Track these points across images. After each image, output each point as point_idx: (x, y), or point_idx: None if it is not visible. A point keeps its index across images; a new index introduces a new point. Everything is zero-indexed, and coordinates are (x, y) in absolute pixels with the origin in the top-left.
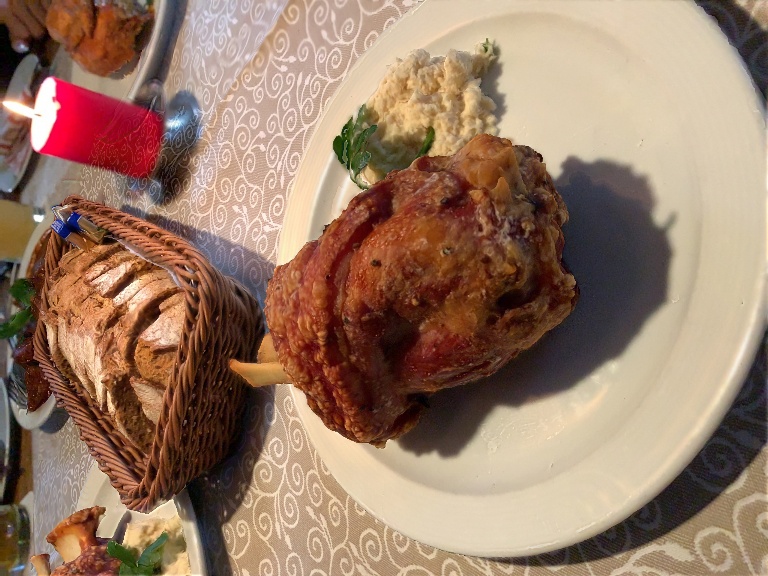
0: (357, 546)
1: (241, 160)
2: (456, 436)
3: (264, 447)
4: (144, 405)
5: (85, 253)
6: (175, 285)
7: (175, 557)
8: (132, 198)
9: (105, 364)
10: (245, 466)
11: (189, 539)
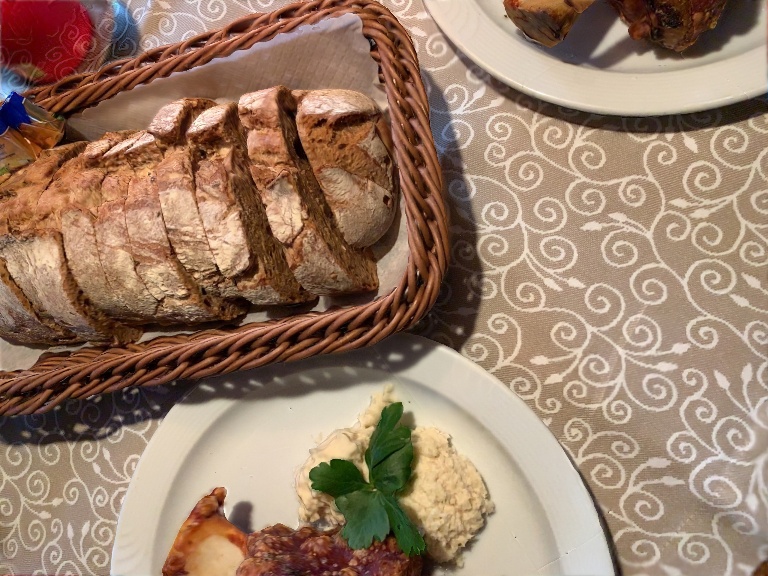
0: (683, 195)
1: (245, 0)
2: (746, 12)
3: (477, 223)
4: (337, 205)
5: (23, 168)
6: None
7: (412, 436)
8: None
9: (233, 196)
10: (462, 258)
11: (447, 369)
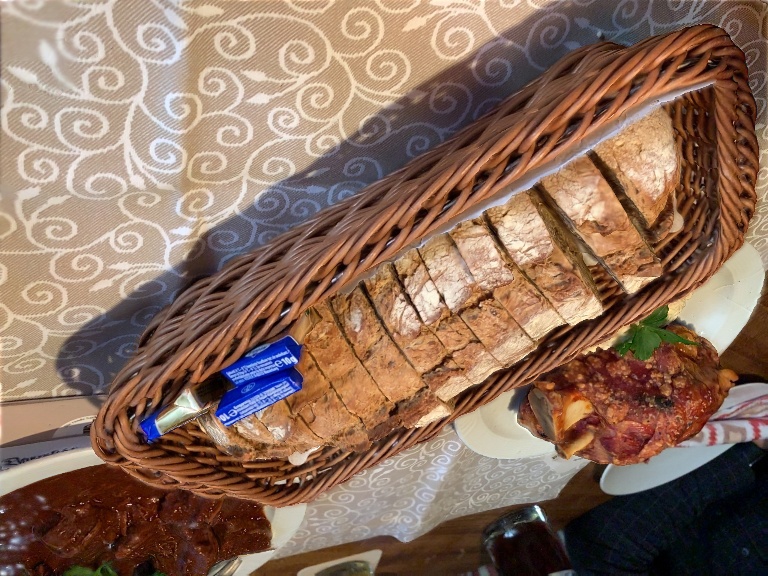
0: None
1: None
2: None
3: None
4: None
5: None
6: None
7: None
8: (93, 304)
9: None
10: None
11: None
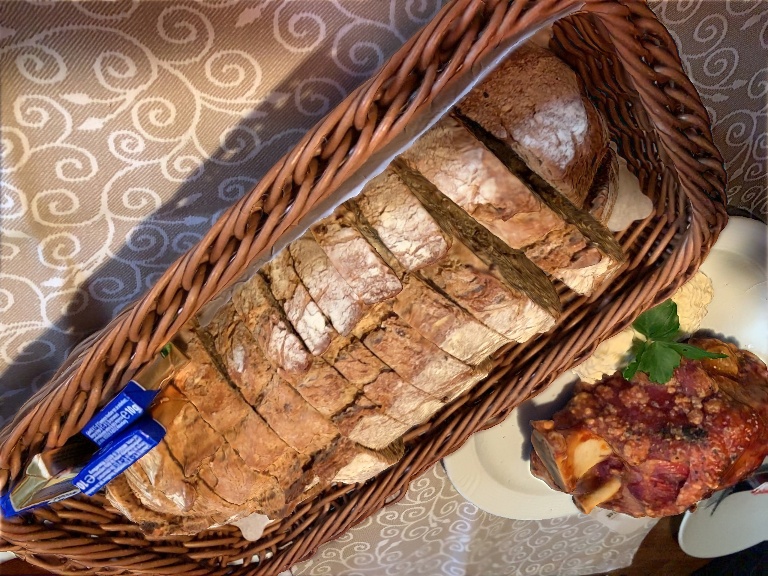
0: None
1: None
2: None
3: None
4: (607, 218)
5: (176, 416)
6: (443, 120)
7: None
8: None
9: (519, 293)
10: None
11: None
